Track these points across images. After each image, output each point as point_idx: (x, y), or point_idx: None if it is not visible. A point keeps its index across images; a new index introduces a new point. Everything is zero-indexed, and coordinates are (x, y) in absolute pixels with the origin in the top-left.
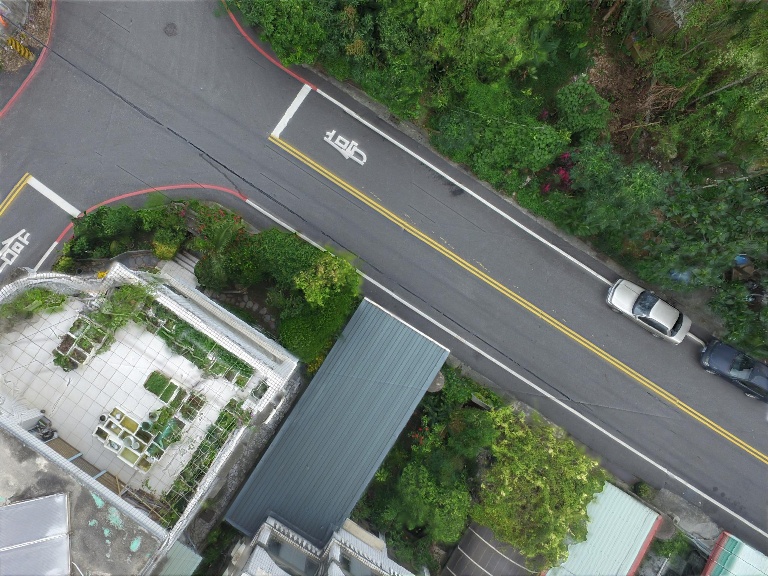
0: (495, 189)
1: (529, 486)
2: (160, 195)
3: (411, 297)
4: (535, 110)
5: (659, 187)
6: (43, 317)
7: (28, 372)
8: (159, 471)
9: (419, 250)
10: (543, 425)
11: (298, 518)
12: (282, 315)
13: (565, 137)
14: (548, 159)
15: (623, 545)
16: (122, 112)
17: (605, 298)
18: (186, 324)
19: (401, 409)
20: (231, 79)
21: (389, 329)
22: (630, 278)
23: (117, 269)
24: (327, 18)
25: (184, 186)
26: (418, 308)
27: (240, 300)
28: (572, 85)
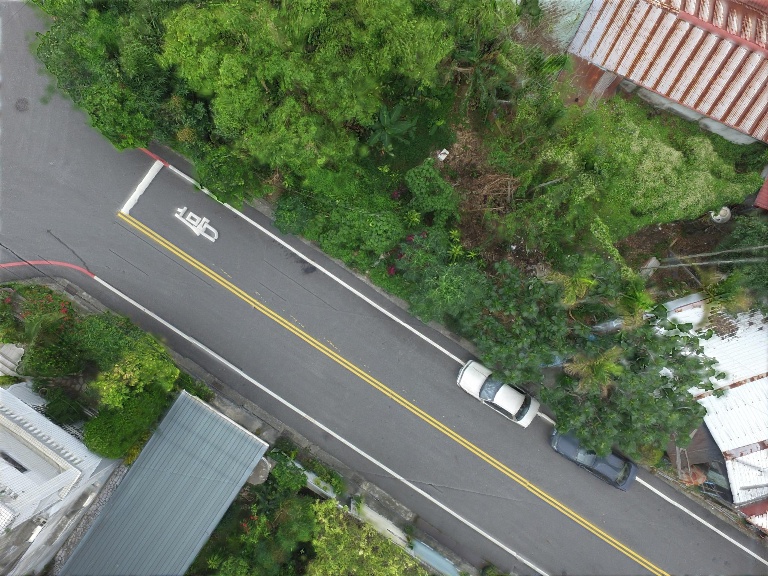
0: (348, 267)
1: None
2: (6, 271)
3: (260, 376)
4: (391, 187)
5: (466, 290)
6: None
7: None
8: None
9: (269, 328)
10: (392, 507)
11: None
12: (99, 407)
13: (414, 218)
14: (387, 245)
15: None
16: None
17: (456, 379)
18: None
19: (216, 505)
20: (82, 154)
21: (207, 422)
22: None
23: None
24: (153, 107)
25: (31, 262)
26: (267, 387)
27: (76, 382)
28: (417, 168)
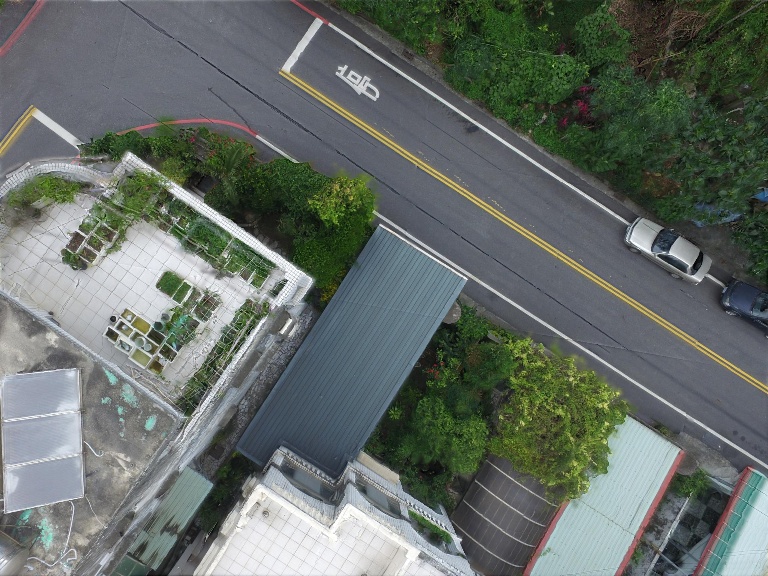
0: (511, 126)
1: (549, 415)
2: (168, 129)
3: (425, 236)
4: (551, 47)
5: (685, 104)
6: (51, 216)
7: (35, 273)
8: (172, 373)
9: (433, 188)
10: None
11: (311, 449)
12: (295, 242)
13: None
14: (567, 89)
15: (644, 480)
16: (129, 44)
17: (623, 237)
18: (200, 219)
19: (417, 338)
20: (241, 12)
21: (405, 256)
22: (648, 218)
23: (129, 159)
24: None
25: (192, 121)
26: (432, 247)
27: None
28: (591, 16)
